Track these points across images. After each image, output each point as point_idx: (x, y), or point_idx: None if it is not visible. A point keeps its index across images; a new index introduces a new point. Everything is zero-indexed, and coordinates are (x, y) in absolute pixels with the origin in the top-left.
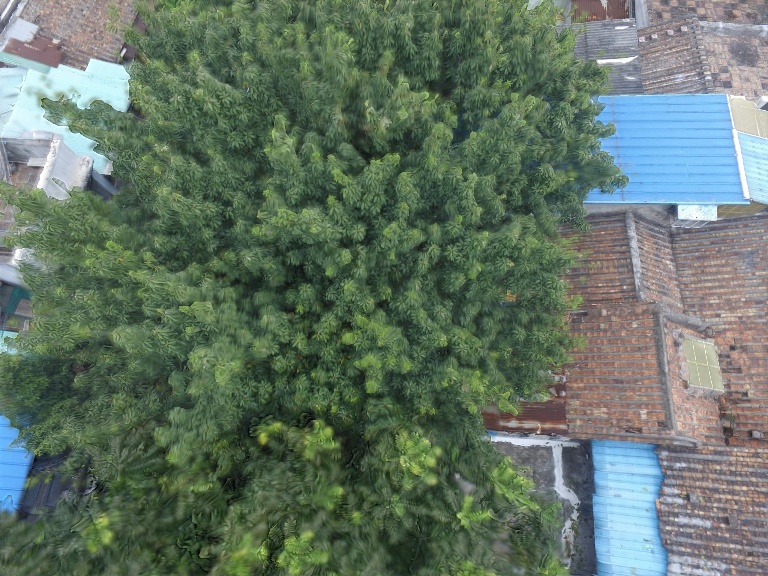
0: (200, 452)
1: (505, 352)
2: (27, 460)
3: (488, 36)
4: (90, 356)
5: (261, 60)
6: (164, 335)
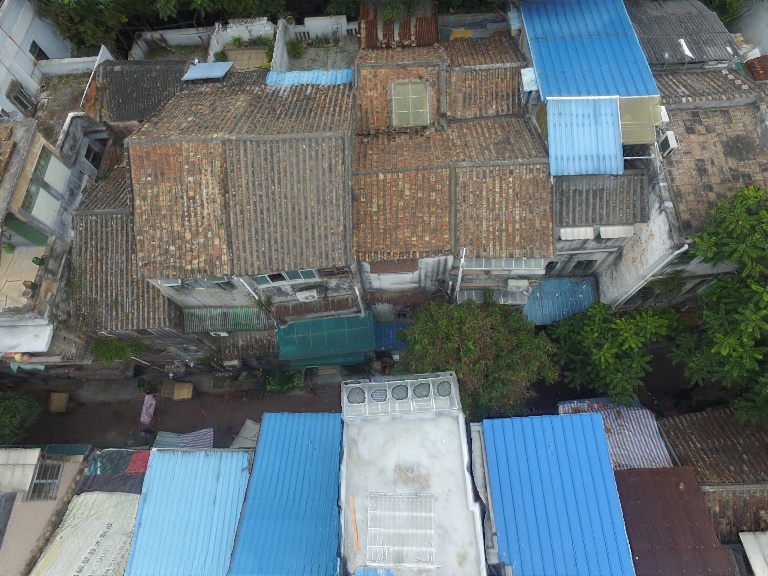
0: None
1: None
2: None
3: None
4: None
5: None
6: None
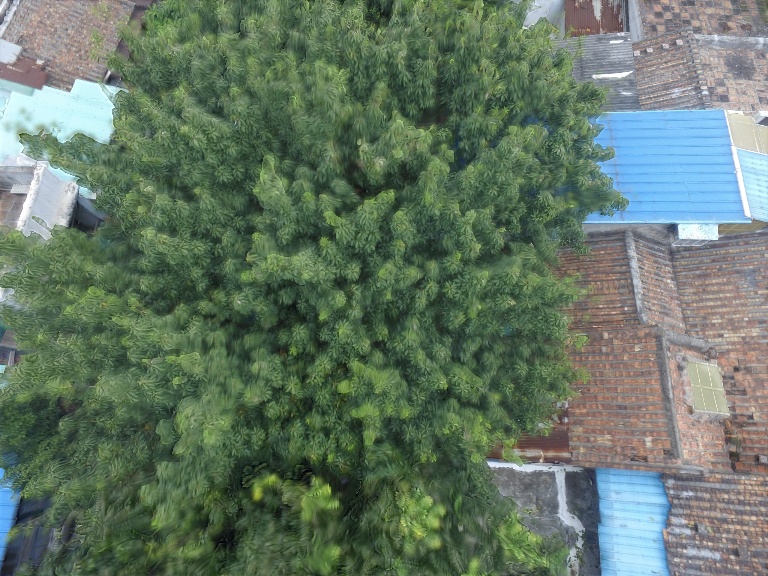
0: (190, 504)
1: (507, 388)
2: (13, 500)
3: (484, 65)
4: (76, 396)
5: (249, 91)
6: (150, 385)
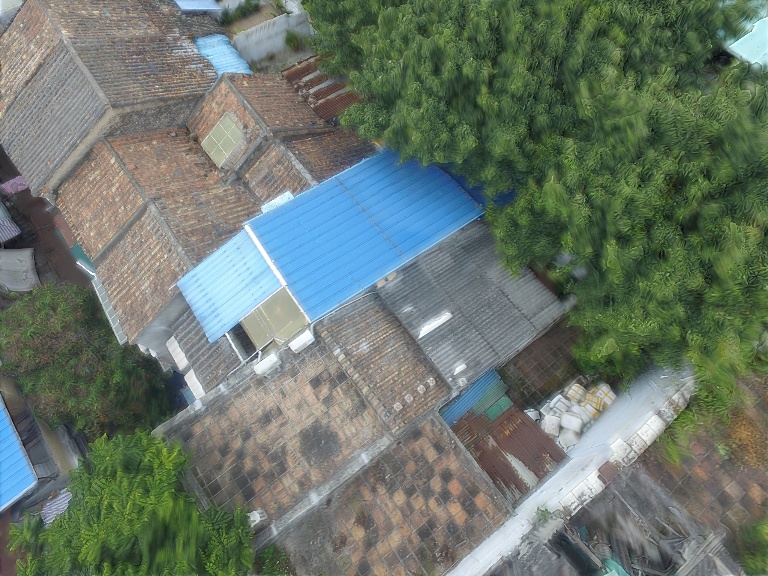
0: None
1: None
2: None
3: None
4: None
5: None
6: None
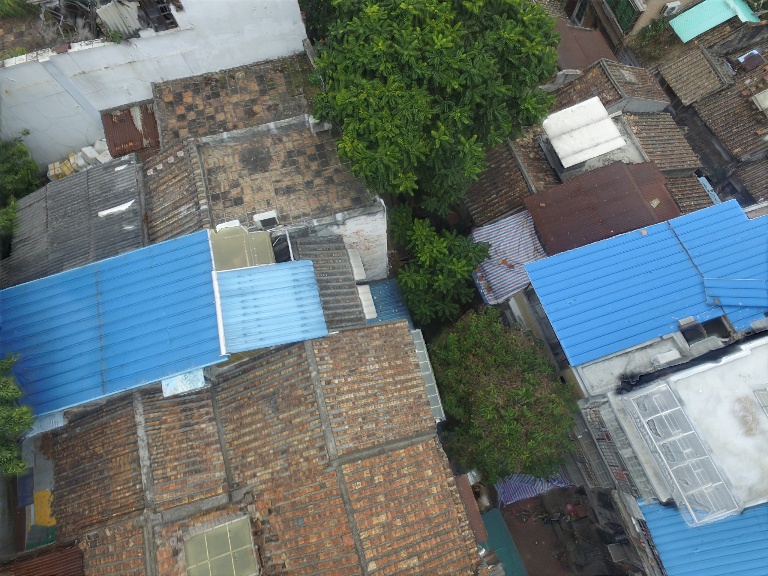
0: None
1: None
2: None
3: None
4: None
5: None
6: None
